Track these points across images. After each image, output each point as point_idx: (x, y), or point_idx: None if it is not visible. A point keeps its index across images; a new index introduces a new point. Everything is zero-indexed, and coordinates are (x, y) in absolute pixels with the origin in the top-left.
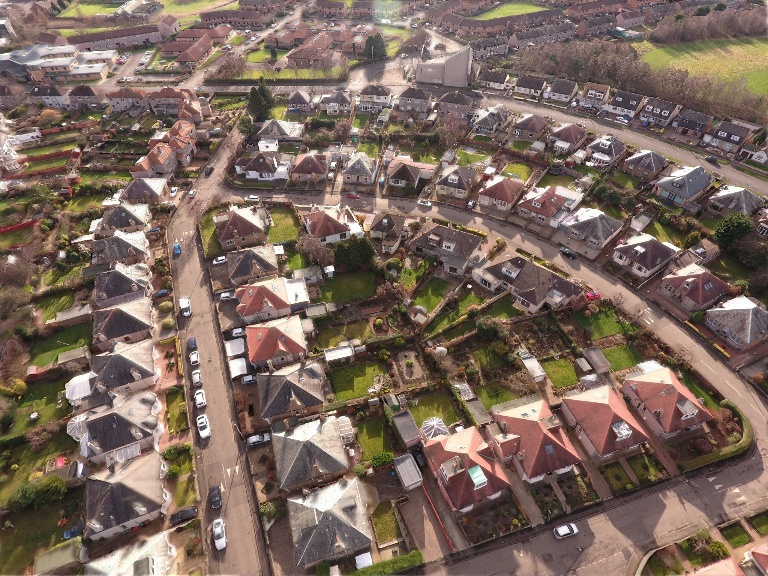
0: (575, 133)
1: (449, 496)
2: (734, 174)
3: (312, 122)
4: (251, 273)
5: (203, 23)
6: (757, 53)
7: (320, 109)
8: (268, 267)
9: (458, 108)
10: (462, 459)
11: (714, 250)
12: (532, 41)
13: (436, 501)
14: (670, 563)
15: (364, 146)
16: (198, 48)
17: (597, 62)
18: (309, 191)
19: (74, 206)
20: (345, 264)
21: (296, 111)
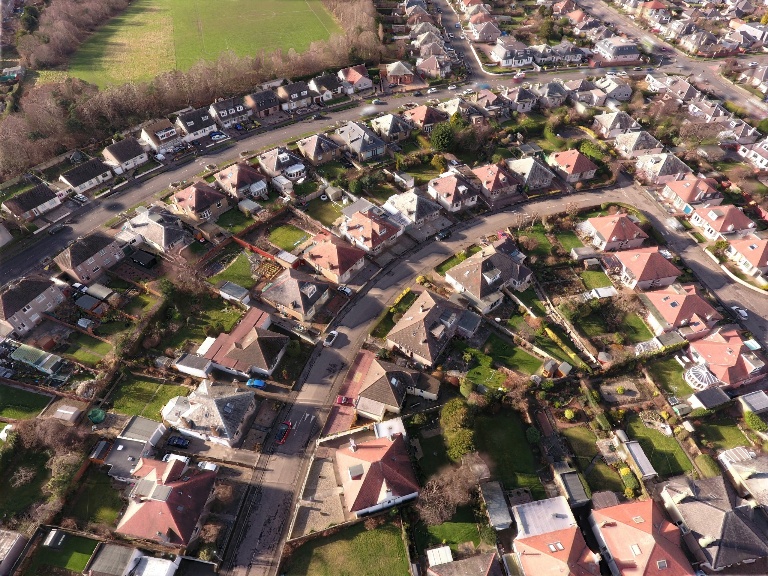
0: (250, 170)
1: (767, 372)
2: (342, 115)
3: None
4: None
5: None
6: (139, 35)
7: None
8: (496, 570)
9: (105, 254)
10: (744, 352)
11: (453, 156)
12: None
13: (759, 389)
14: (736, 269)
15: (124, 404)
16: None
17: (92, 109)
18: (241, 513)
19: None
20: None
21: None
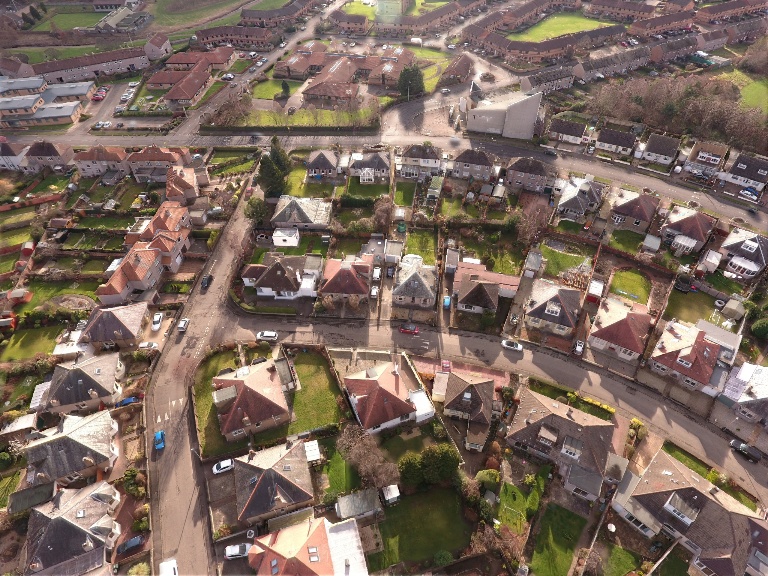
0: (702, 225)
1: None
2: None
3: (342, 199)
4: (272, 509)
5: (199, 42)
6: None
7: (350, 175)
8: (298, 496)
9: (533, 179)
10: None
11: None
12: (601, 71)
13: None
14: None
15: (414, 237)
16: (193, 80)
17: (698, 108)
18: (346, 319)
19: (16, 348)
20: (416, 484)
21: (319, 177)
